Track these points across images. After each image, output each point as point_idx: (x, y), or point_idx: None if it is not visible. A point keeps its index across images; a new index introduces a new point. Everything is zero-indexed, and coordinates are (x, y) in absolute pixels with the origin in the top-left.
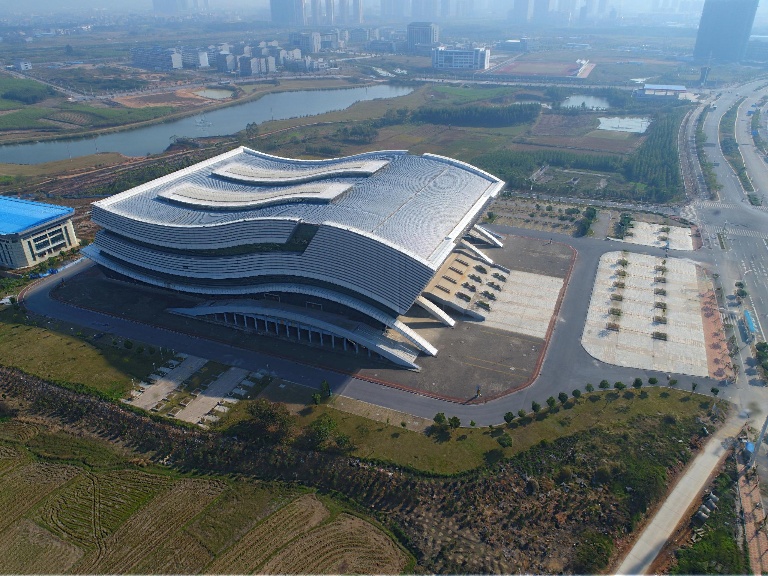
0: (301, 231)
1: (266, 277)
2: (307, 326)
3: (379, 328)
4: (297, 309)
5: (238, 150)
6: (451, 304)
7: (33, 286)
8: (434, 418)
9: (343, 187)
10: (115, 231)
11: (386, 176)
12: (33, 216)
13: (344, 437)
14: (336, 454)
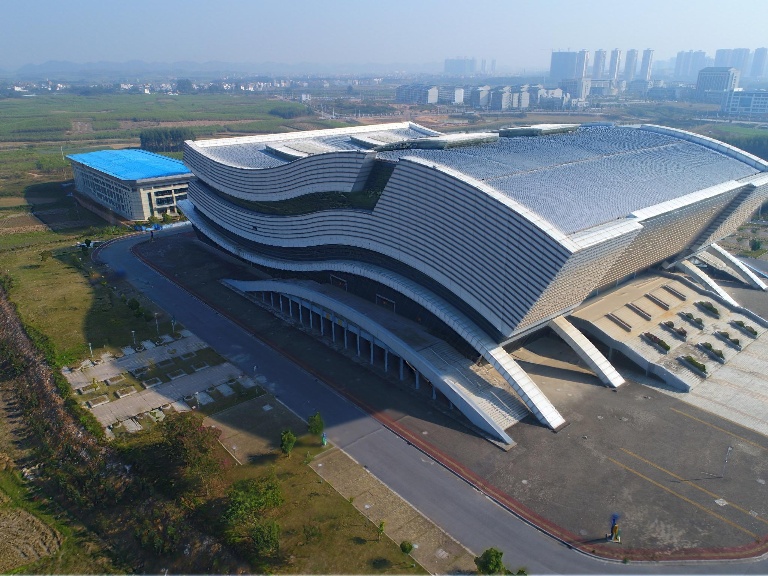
0: (377, 175)
1: (333, 249)
2: (356, 327)
3: (468, 355)
4: (361, 303)
5: (402, 124)
6: (625, 348)
7: (128, 237)
8: (477, 557)
9: (479, 134)
10: (200, 177)
11: (563, 137)
12: (166, 170)
13: (267, 531)
14: (245, 561)
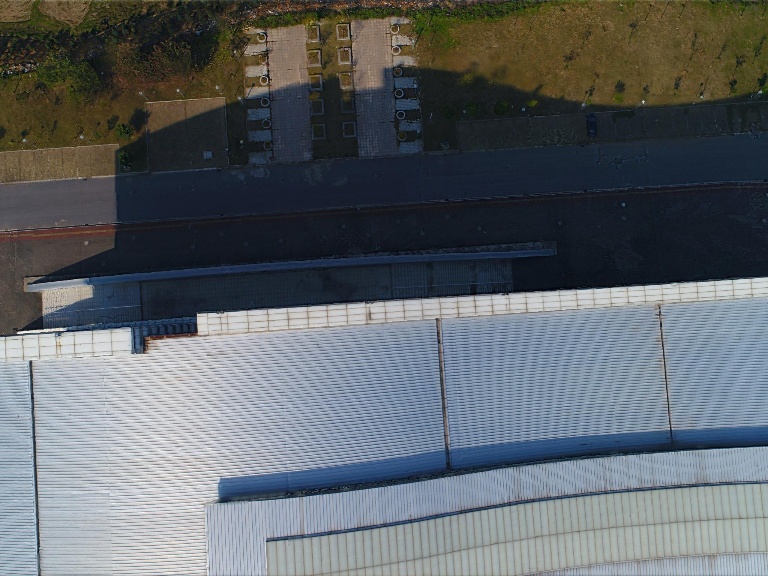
0: None
1: None
2: None
3: None
4: None
5: None
6: None
7: None
8: None
9: None
10: None
11: None
12: None
13: None
14: None
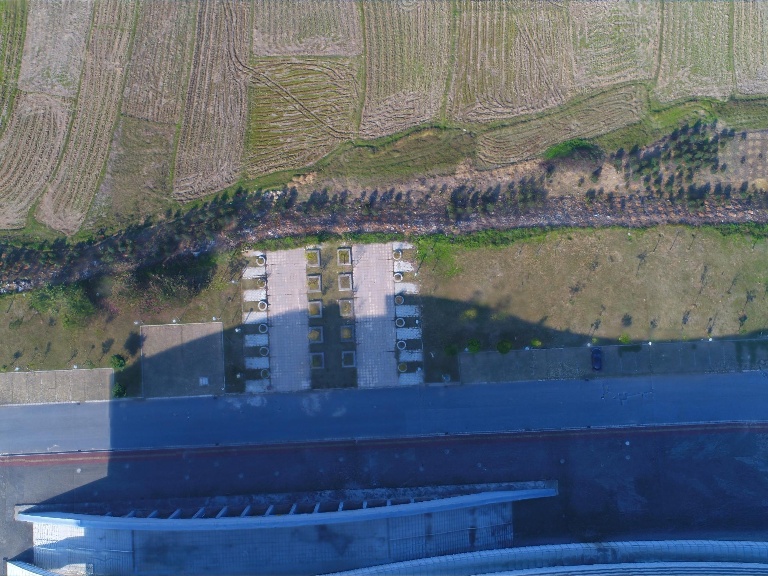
0: None
1: None
2: None
3: None
4: (275, 568)
5: None
6: None
7: None
8: None
9: None
10: None
11: None
12: None
13: None
14: None
